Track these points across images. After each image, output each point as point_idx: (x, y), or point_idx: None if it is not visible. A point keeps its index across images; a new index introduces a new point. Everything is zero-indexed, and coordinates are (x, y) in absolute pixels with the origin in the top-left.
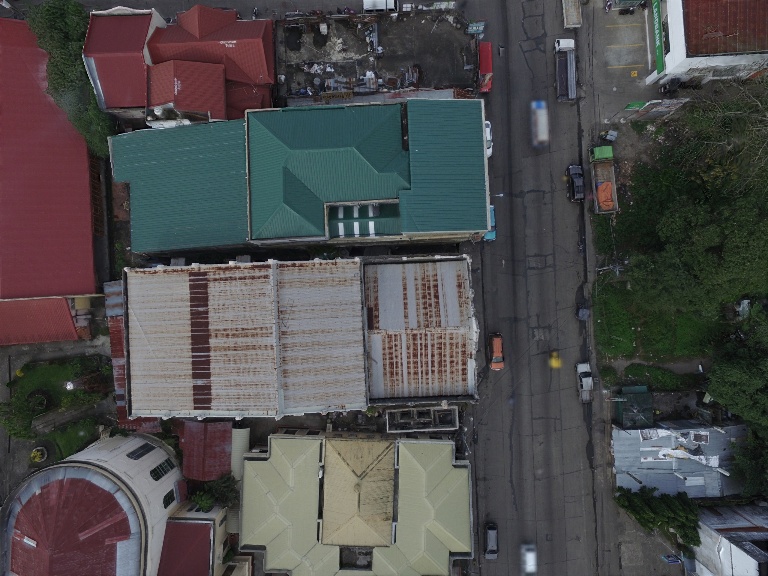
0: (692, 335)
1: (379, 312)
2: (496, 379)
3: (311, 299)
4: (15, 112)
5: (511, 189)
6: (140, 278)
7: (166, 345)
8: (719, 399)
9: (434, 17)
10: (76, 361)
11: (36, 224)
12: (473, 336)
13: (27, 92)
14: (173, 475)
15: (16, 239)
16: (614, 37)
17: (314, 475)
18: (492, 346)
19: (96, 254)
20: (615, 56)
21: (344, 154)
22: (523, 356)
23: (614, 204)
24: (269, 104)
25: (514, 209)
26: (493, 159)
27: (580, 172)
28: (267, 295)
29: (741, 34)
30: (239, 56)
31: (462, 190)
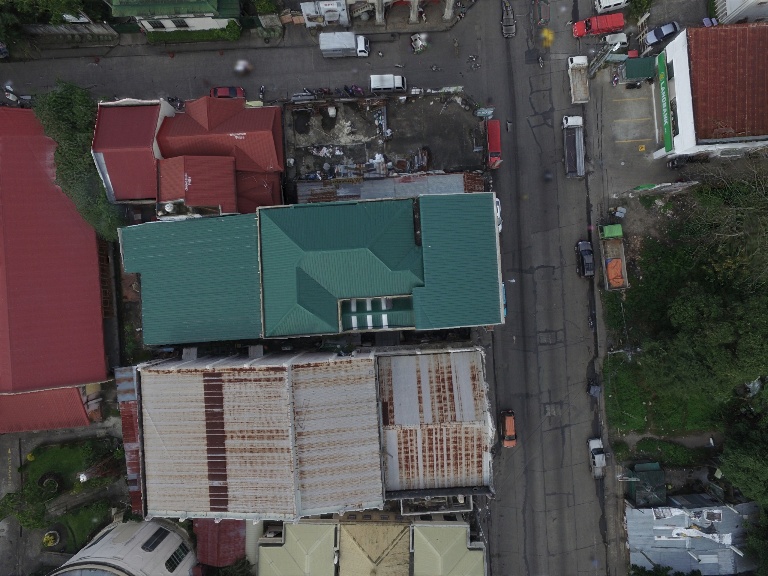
0: (703, 409)
1: (394, 406)
2: (508, 455)
3: (326, 399)
4: (23, 202)
5: (521, 265)
6: (154, 377)
7: (181, 446)
8: (732, 482)
9: (443, 99)
10: (87, 445)
11: (46, 314)
12: (488, 430)
13: (35, 181)
14: (188, 561)
15: (26, 331)
16: (621, 111)
17: (329, 560)
18: (505, 425)
19: (106, 338)
20: (623, 130)
21: (358, 254)
22: (535, 432)
23: (624, 281)
24: (279, 191)
25: (524, 285)
26: (502, 235)
27: (590, 248)
28: (283, 398)
29: (750, 118)
30: (249, 147)
31: (475, 284)
